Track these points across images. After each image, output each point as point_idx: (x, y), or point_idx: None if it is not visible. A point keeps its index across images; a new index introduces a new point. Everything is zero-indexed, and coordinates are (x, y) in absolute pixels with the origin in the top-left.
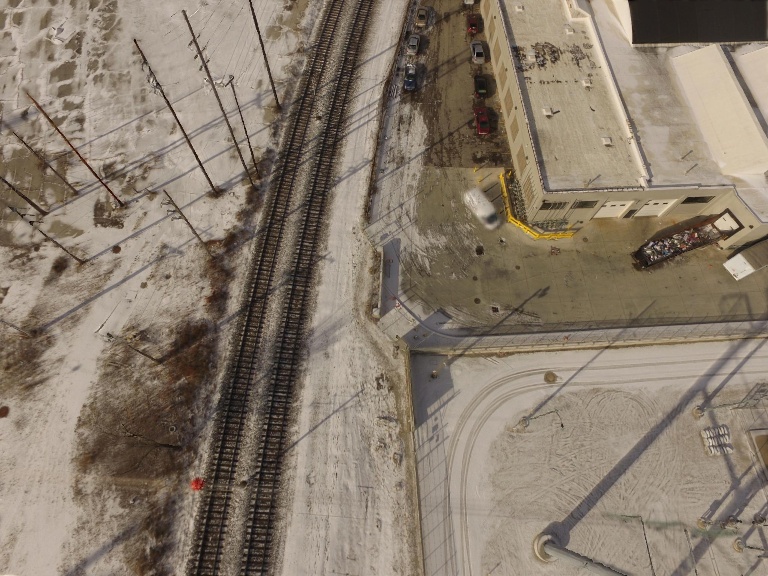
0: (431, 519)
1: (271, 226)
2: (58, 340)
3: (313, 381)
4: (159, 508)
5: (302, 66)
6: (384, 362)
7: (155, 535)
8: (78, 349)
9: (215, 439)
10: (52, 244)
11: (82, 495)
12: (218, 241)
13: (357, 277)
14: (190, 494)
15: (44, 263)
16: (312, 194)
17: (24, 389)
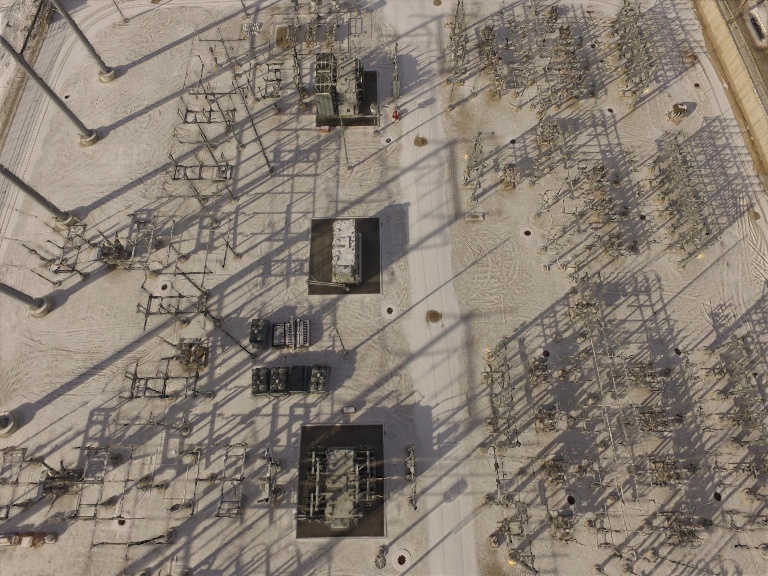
0: (42, 63)
1: None
2: None
3: None
4: None
5: None
6: None
7: None
8: None
9: None
10: None
11: None
12: None
13: None
14: None
15: None
16: None
17: None
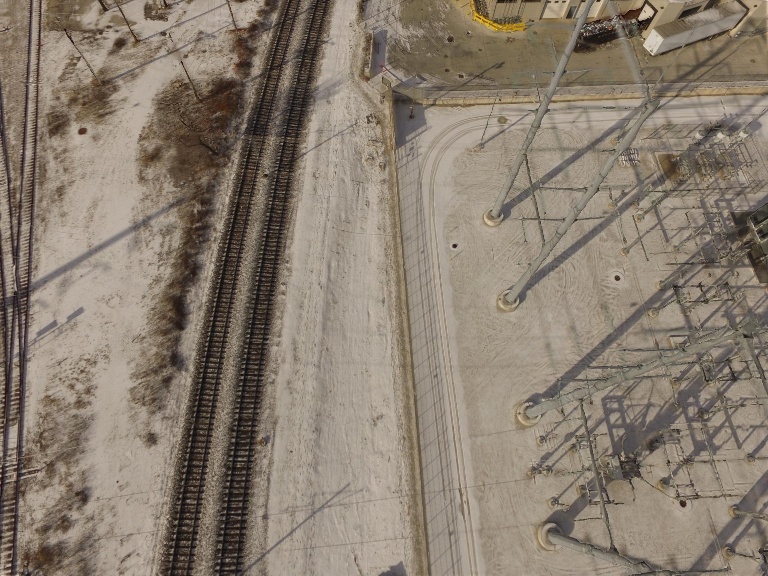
0: (407, 201)
1: (285, 22)
2: (121, 88)
3: (318, 117)
4: (203, 188)
5: None
6: (373, 106)
7: (200, 203)
8: (137, 93)
9: (243, 150)
10: (113, 30)
11: (145, 180)
12: (243, 29)
13: (353, 54)
14: (225, 182)
15: (107, 42)
16: (317, 1)
17: (97, 117)
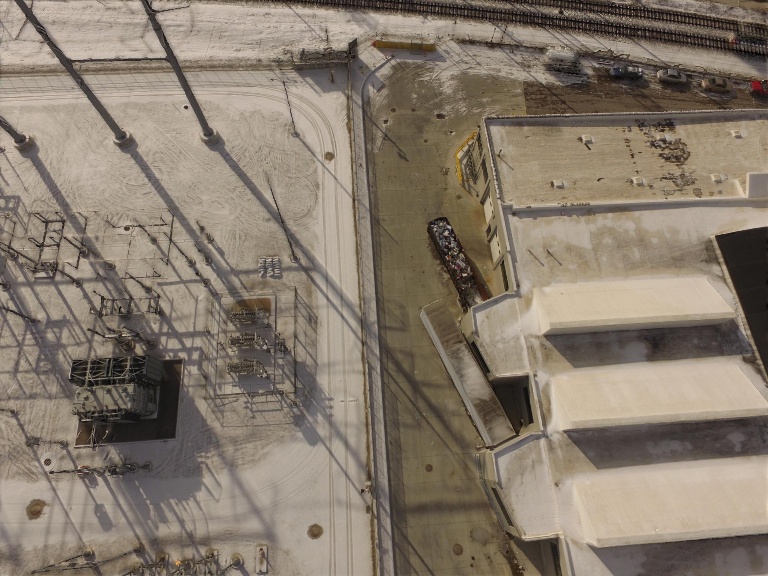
0: (237, 76)
1: None
2: None
3: (330, 14)
4: None
5: (619, 1)
6: None
7: None
8: None
9: None
10: None
11: None
12: None
13: (410, 36)
14: None
15: None
16: (483, 10)
17: None
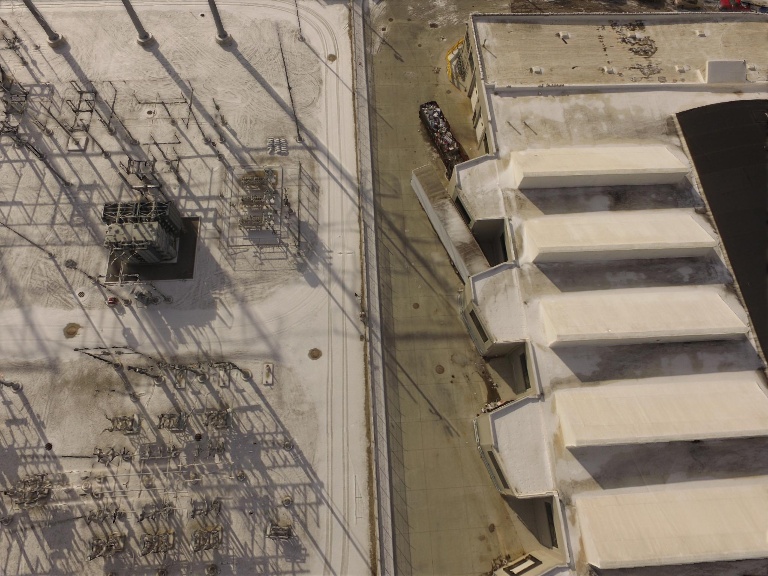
0: None
1: None
2: None
3: None
4: None
5: None
6: None
7: None
8: None
9: None
10: None
11: None
12: None
13: None
14: None
15: None
16: None
17: None
